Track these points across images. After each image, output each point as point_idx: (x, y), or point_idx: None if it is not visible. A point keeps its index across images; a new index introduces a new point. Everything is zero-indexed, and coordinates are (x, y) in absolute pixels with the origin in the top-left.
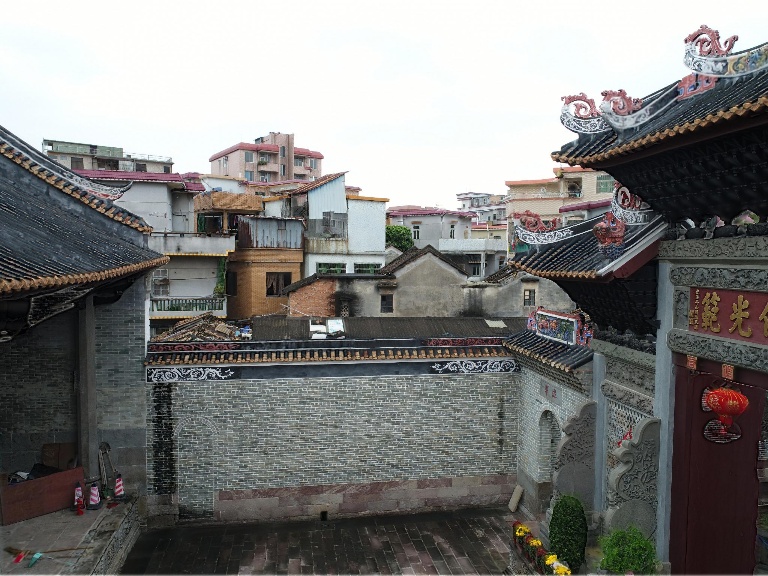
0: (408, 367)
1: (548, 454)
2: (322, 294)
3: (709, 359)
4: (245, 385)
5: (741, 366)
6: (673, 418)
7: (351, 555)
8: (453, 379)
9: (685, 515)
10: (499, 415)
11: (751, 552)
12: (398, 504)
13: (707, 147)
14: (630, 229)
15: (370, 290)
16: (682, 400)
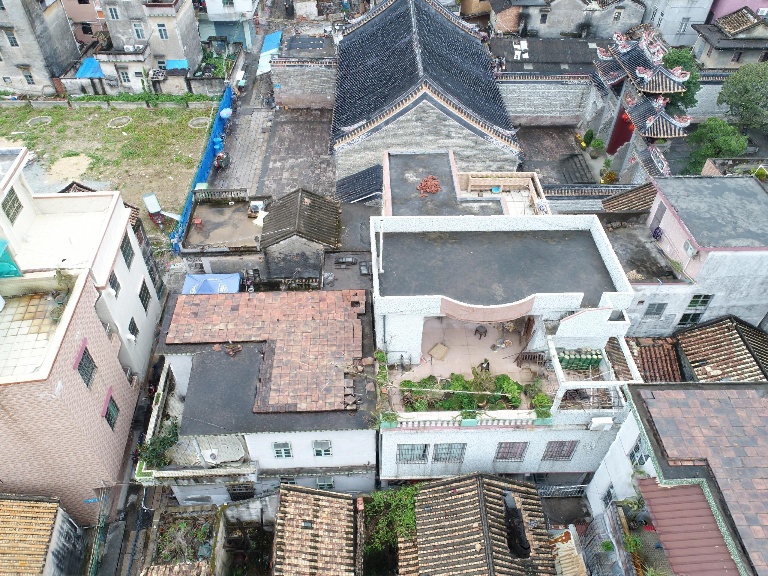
0: (555, 82)
1: (593, 113)
2: (513, 14)
3: None
4: (504, 86)
5: None
6: (617, 117)
7: (530, 137)
8: (569, 86)
9: (613, 137)
10: (581, 98)
11: None
12: (543, 123)
13: None
14: None
15: (537, 12)
16: (619, 113)
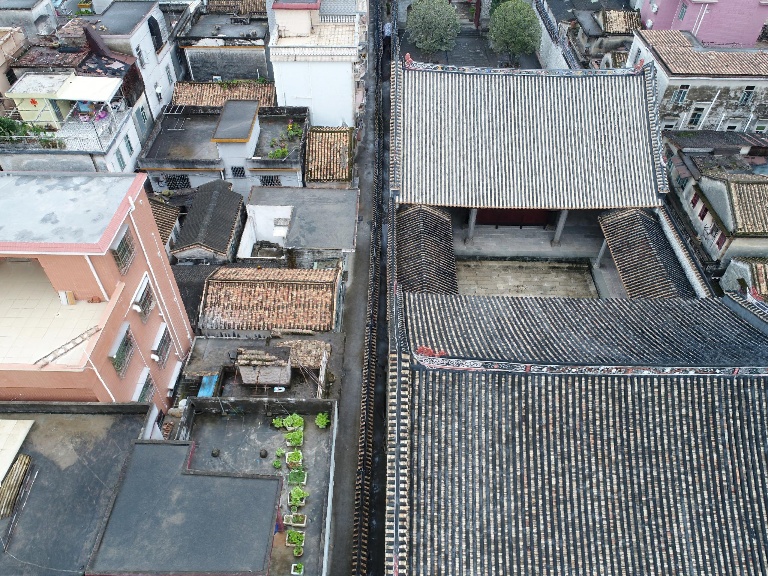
0: None
1: None
2: None
3: None
4: None
5: None
6: None
7: None
8: None
9: None
10: None
11: (477, 22)
12: None
13: None
14: None
15: None
16: None
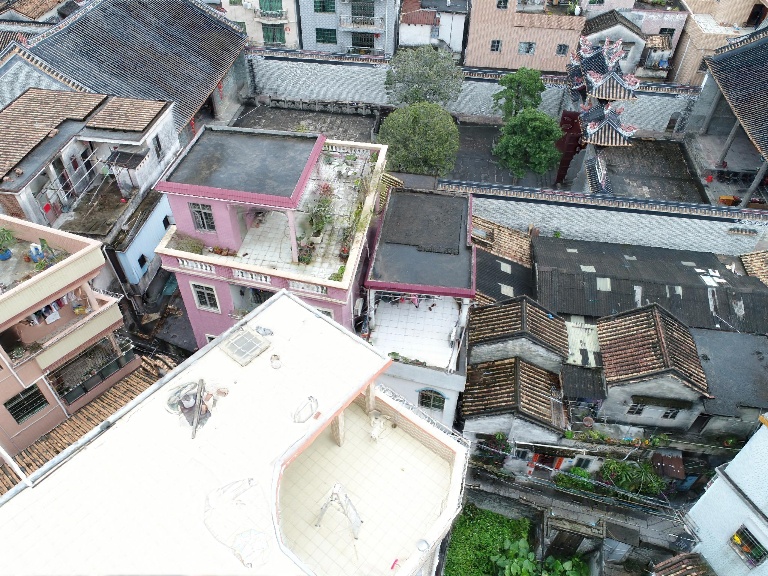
0: None
1: None
2: None
3: None
4: None
5: None
6: None
7: None
8: None
9: None
10: None
11: None
12: None
13: None
14: None
15: None
16: None
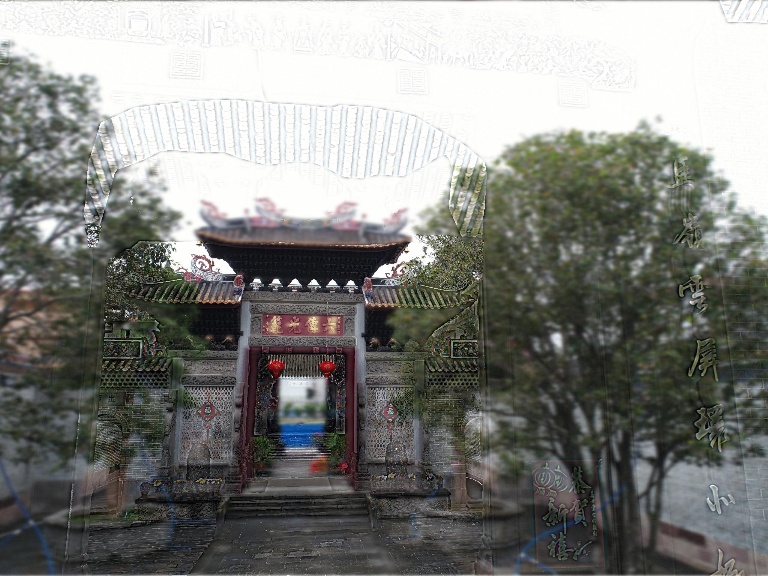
0: None
1: None
2: None
3: (277, 346)
4: None
5: (297, 346)
6: (248, 382)
7: None
8: None
9: None
10: None
11: None
12: None
13: (300, 252)
14: (214, 283)
15: None
16: (255, 371)
